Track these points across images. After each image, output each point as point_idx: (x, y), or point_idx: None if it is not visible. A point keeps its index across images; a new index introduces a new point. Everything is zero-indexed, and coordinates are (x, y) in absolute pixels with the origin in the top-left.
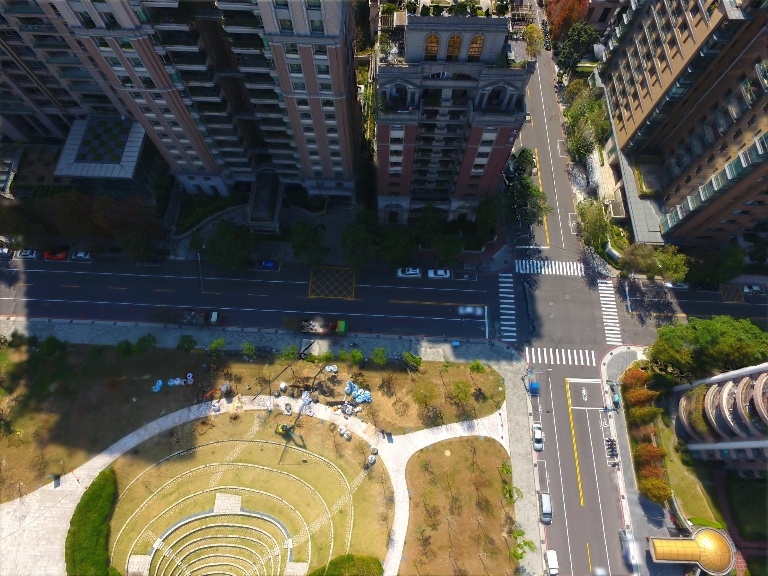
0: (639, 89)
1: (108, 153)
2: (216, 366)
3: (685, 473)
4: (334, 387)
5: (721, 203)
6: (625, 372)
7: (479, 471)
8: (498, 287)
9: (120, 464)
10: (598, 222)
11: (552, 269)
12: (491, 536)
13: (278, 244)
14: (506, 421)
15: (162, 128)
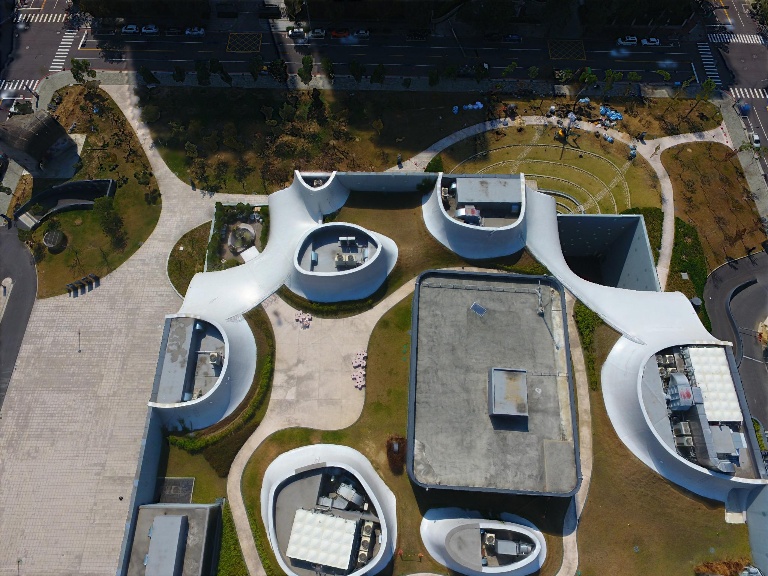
0: None
1: None
2: (496, 97)
3: None
4: (591, 111)
5: None
6: None
7: (716, 160)
8: (698, 51)
9: (444, 155)
10: None
11: (738, 39)
12: (736, 198)
13: (516, 25)
14: (727, 132)
15: None
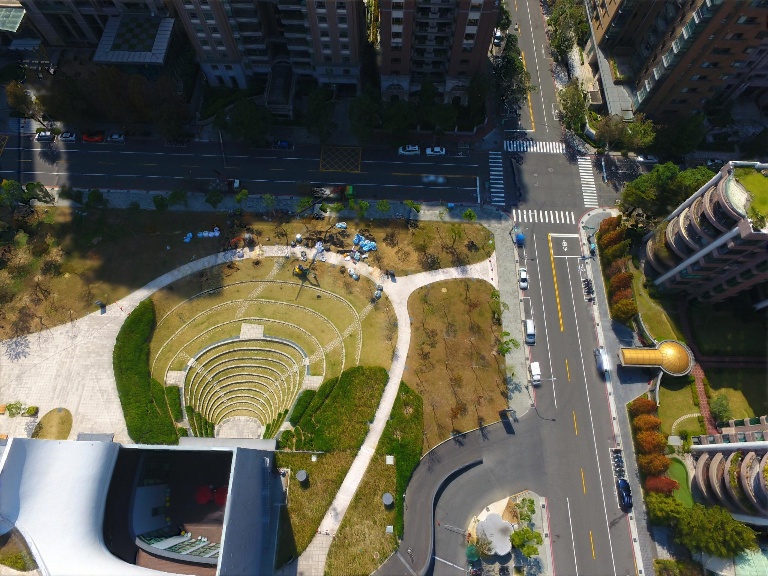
0: None
1: (140, 43)
2: (239, 222)
3: (652, 304)
4: (344, 239)
5: (681, 68)
6: (600, 224)
7: None
8: (488, 162)
9: (157, 297)
10: (576, 97)
11: (537, 148)
12: (482, 353)
13: (292, 128)
14: (495, 266)
15: (192, 6)
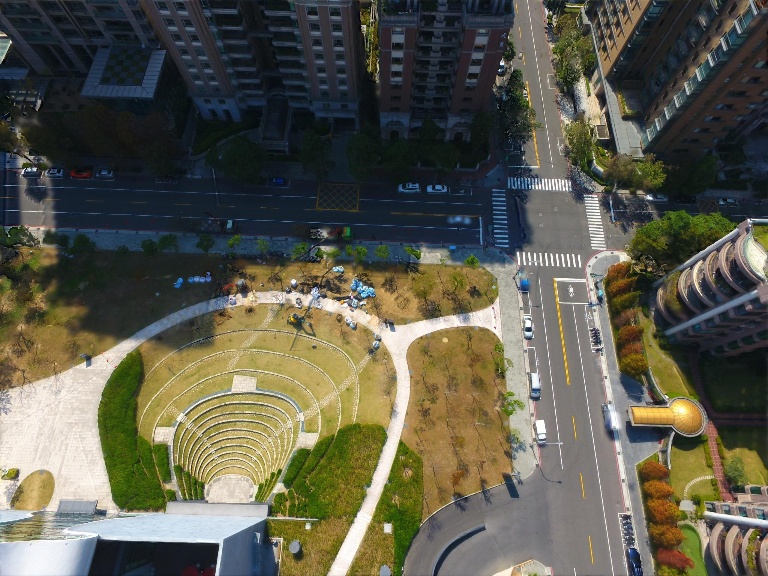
0: (621, 17)
1: (130, 77)
2: (232, 266)
3: (662, 356)
4: (341, 284)
5: (694, 109)
6: (608, 269)
7: (474, 355)
8: (492, 201)
9: (146, 348)
10: (583, 135)
11: (542, 185)
12: (485, 409)
13: (287, 164)
14: (499, 314)
15: (183, 43)
